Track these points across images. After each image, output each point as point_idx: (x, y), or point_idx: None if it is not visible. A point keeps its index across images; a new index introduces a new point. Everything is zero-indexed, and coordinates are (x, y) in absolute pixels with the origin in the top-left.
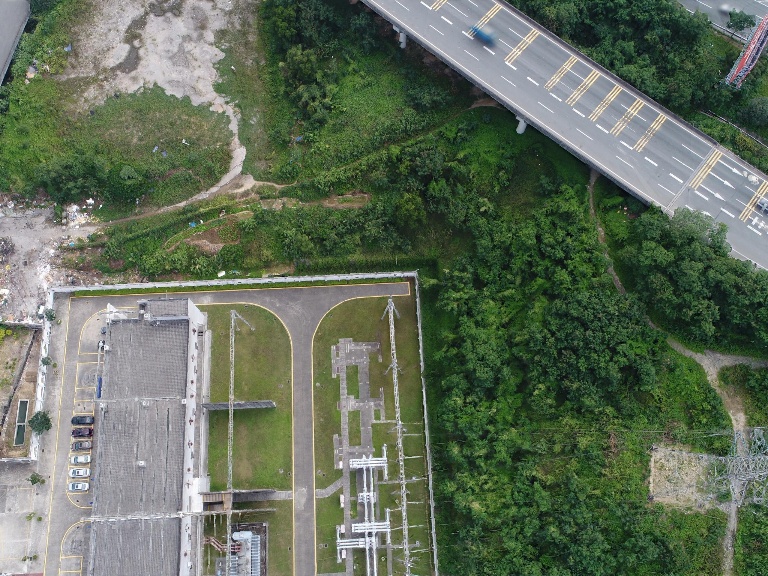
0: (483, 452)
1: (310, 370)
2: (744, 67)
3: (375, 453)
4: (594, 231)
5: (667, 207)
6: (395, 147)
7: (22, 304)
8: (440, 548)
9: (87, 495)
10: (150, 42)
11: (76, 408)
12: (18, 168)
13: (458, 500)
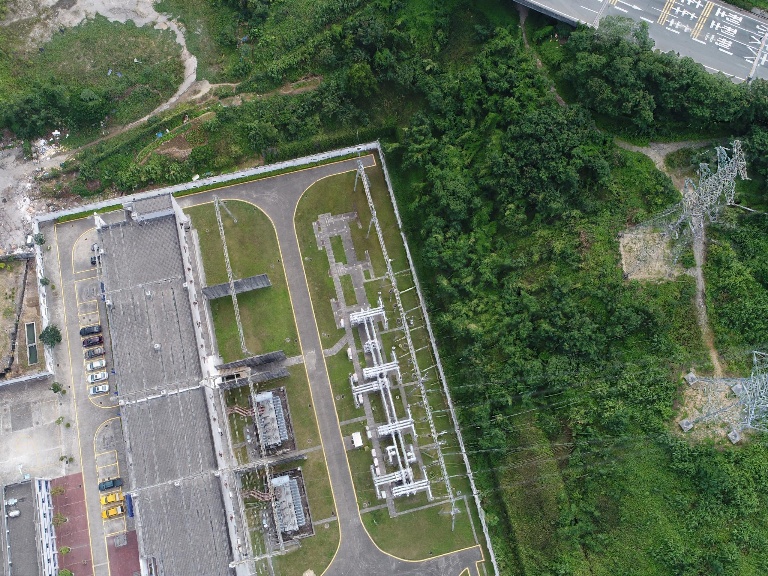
0: (470, 279)
1: (297, 247)
2: None
3: (372, 308)
4: (532, 60)
5: (592, 24)
6: (337, 26)
7: (9, 238)
8: (448, 378)
9: (109, 396)
10: None
11: (82, 322)
12: None
13: (456, 324)
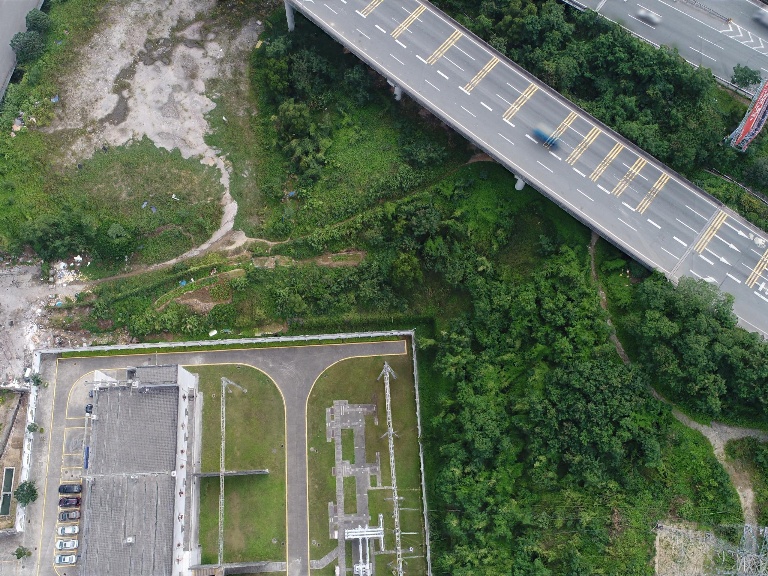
0: (482, 525)
1: (304, 434)
2: (750, 132)
3: (371, 521)
4: (596, 296)
5: (671, 272)
6: (390, 204)
7: (8, 366)
8: None
9: (74, 568)
10: (139, 92)
11: (63, 476)
12: (4, 225)
13: None
